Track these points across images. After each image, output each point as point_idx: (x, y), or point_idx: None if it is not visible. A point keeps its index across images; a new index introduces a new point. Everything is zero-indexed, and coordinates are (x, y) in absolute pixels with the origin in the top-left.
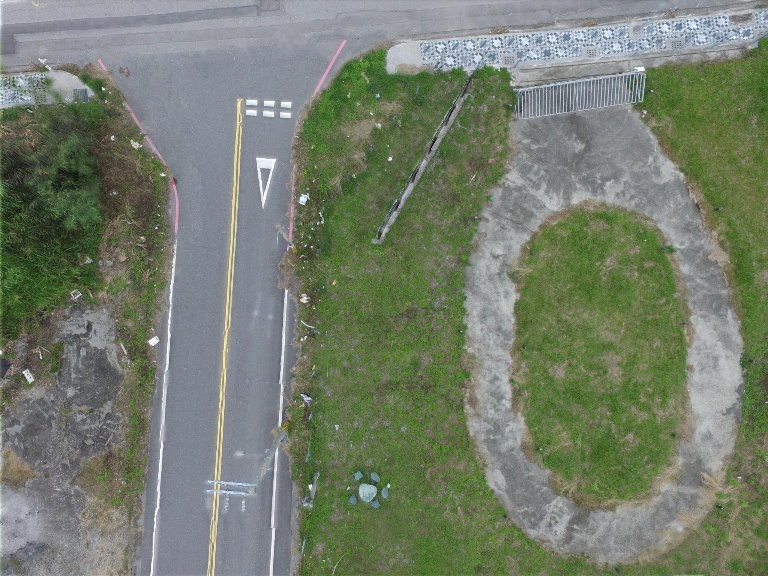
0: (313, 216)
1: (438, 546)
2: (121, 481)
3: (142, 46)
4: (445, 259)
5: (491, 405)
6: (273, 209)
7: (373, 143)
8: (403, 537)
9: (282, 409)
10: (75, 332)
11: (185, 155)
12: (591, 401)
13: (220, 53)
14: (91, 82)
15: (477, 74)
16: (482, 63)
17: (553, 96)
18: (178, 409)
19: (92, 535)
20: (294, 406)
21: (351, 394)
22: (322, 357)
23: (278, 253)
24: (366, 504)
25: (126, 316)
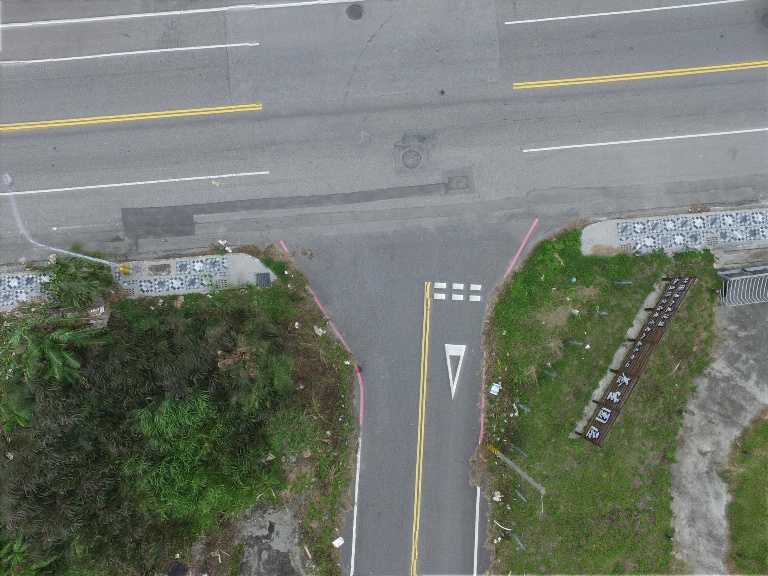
0: (506, 407)
1: None
2: None
3: (326, 226)
4: (649, 456)
5: None
6: (463, 399)
7: (570, 330)
8: None
9: None
10: (256, 533)
11: (370, 341)
12: None
13: (407, 233)
14: (274, 266)
15: (679, 256)
16: (683, 244)
17: (762, 281)
18: None
19: None
20: None
21: None
22: (518, 561)
23: (469, 447)
24: None
25: (310, 517)
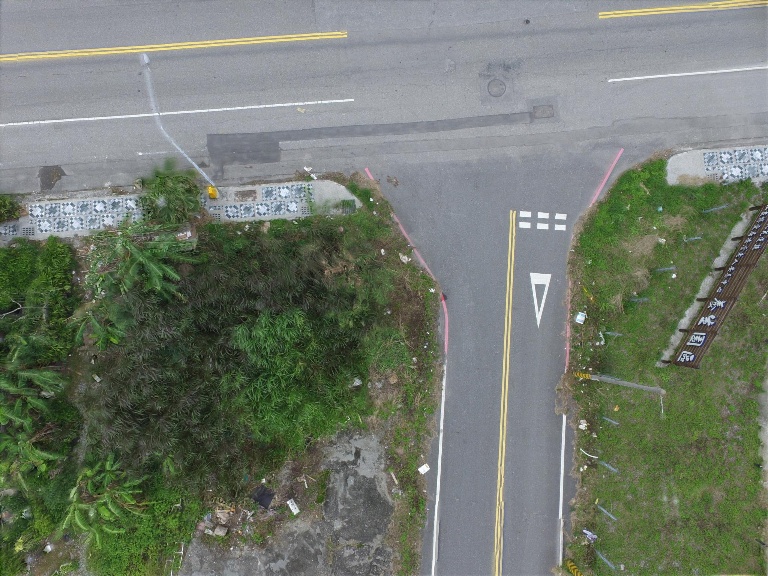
0: (591, 336)
1: None
2: None
3: (411, 154)
4: (736, 385)
5: None
6: (548, 328)
7: (656, 259)
8: None
9: (562, 546)
10: (342, 459)
11: (455, 269)
12: None
13: (492, 162)
14: (360, 193)
15: (767, 186)
16: None
17: None
18: (451, 544)
19: None
20: (575, 543)
21: (637, 531)
22: (604, 489)
23: (555, 375)
24: None
25: (396, 443)
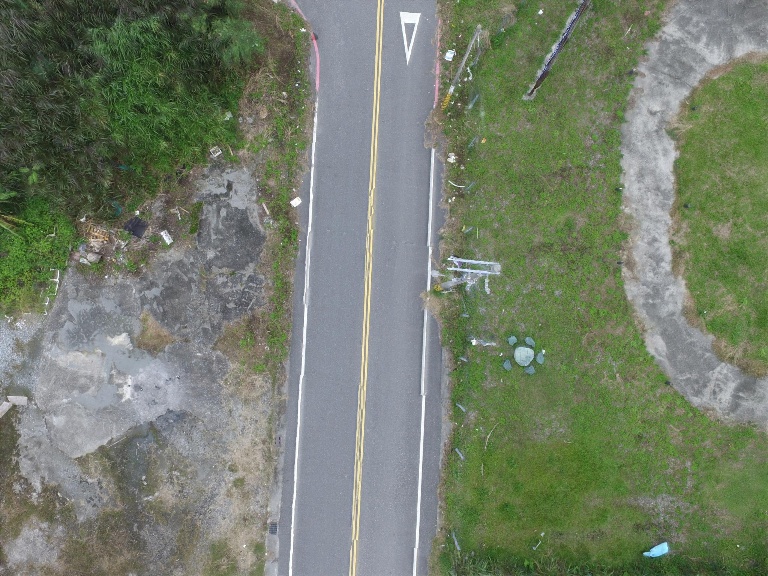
0: None
1: (596, 415)
2: (264, 346)
3: None
4: (600, 115)
5: (650, 268)
6: (418, 65)
7: None
8: (559, 405)
9: None
10: (214, 192)
11: (326, 9)
12: (758, 262)
13: None
14: None
15: None
16: None
17: None
18: (322, 272)
19: (235, 402)
20: (443, 269)
21: (503, 257)
22: (471, 218)
23: (424, 111)
24: (520, 371)
25: (268, 175)
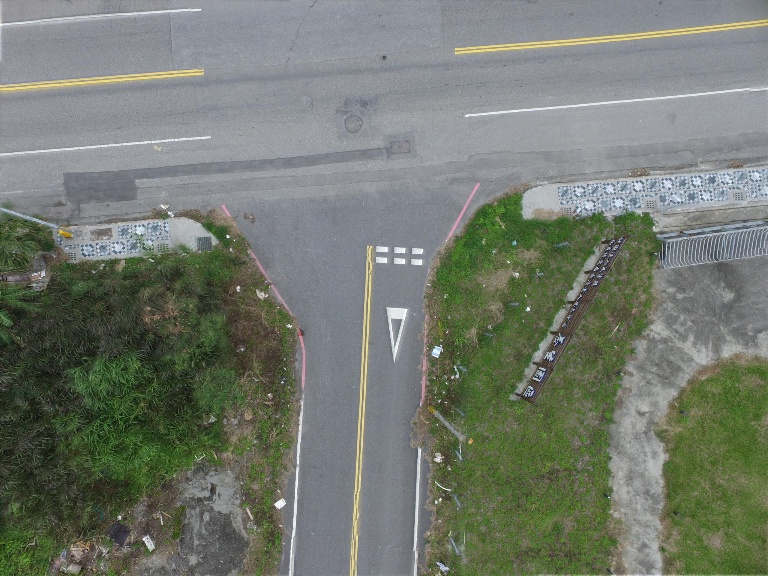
0: (447, 369)
1: None
2: None
3: (268, 191)
4: (588, 416)
5: (640, 574)
6: (404, 362)
7: (510, 293)
8: None
9: None
10: (198, 495)
11: (312, 305)
12: (749, 573)
13: (349, 197)
14: (216, 230)
15: (619, 220)
16: (623, 208)
17: (700, 243)
18: None
19: None
20: (429, 575)
21: (490, 562)
22: (458, 521)
23: (410, 409)
24: None
25: (252, 478)
